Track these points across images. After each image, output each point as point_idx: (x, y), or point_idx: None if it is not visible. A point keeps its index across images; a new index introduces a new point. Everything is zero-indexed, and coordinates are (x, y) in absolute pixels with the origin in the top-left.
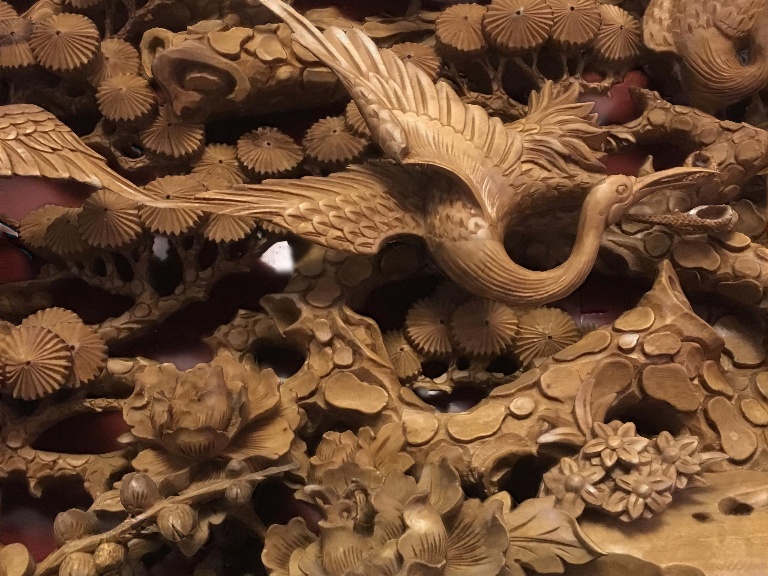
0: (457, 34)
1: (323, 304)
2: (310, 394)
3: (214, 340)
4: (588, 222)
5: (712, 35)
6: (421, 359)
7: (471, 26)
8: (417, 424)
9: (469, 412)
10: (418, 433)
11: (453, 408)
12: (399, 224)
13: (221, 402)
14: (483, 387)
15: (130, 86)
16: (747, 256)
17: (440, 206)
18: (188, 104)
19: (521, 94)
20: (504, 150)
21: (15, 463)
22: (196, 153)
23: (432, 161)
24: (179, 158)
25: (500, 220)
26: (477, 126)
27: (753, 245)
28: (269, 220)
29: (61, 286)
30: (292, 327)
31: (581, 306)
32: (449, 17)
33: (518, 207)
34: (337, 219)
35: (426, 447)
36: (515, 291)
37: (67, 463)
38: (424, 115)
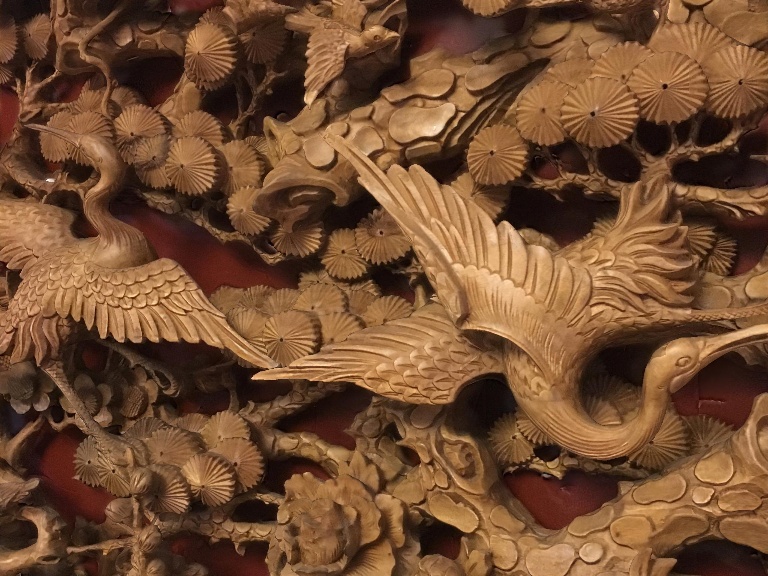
0: (536, 129)
1: (423, 426)
2: (421, 502)
3: (350, 433)
4: (647, 393)
5: None
6: (533, 446)
7: (550, 119)
8: (501, 552)
9: (547, 546)
10: (502, 560)
11: (564, 492)
12: (475, 367)
13: (331, 542)
14: (592, 475)
15: (249, 204)
16: None
17: (510, 353)
18: (298, 218)
19: (621, 174)
20: (569, 298)
21: (221, 534)
22: (320, 249)
23: (488, 327)
24: (306, 256)
25: (570, 368)
26: (539, 275)
27: None
28: (352, 382)
29: (240, 368)
30: (401, 443)
31: (699, 391)
32: (528, 106)
33: (592, 348)
34: (411, 379)
35: (509, 574)
36: (579, 451)
37: (256, 533)
38: (484, 268)
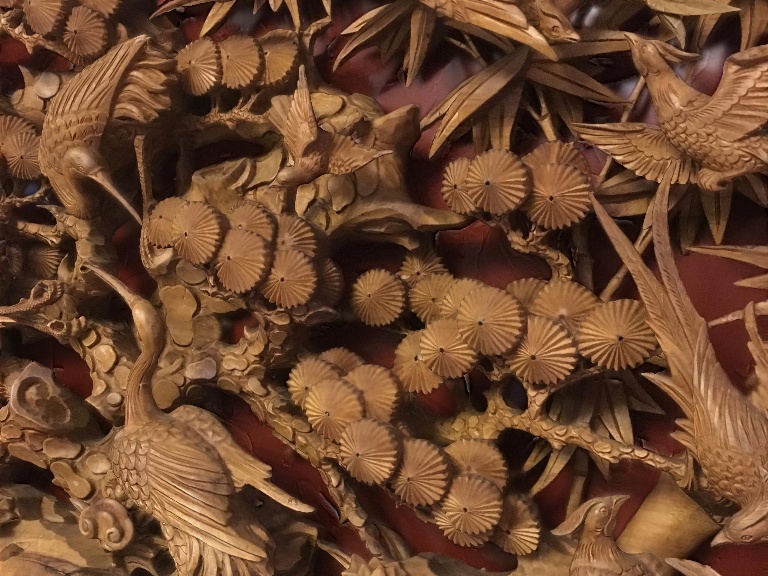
0: None
1: None
2: None
3: None
4: None
5: (53, 174)
6: None
7: None
8: None
9: None
10: None
11: None
12: None
13: None
14: None
15: None
16: (90, 354)
17: None
18: None
19: None
20: None
21: None
22: None
23: None
24: None
25: None
26: None
27: (101, 341)
28: None
29: None
30: None
31: (53, 362)
32: None
33: None
34: None
35: None
36: None
37: None
38: None
